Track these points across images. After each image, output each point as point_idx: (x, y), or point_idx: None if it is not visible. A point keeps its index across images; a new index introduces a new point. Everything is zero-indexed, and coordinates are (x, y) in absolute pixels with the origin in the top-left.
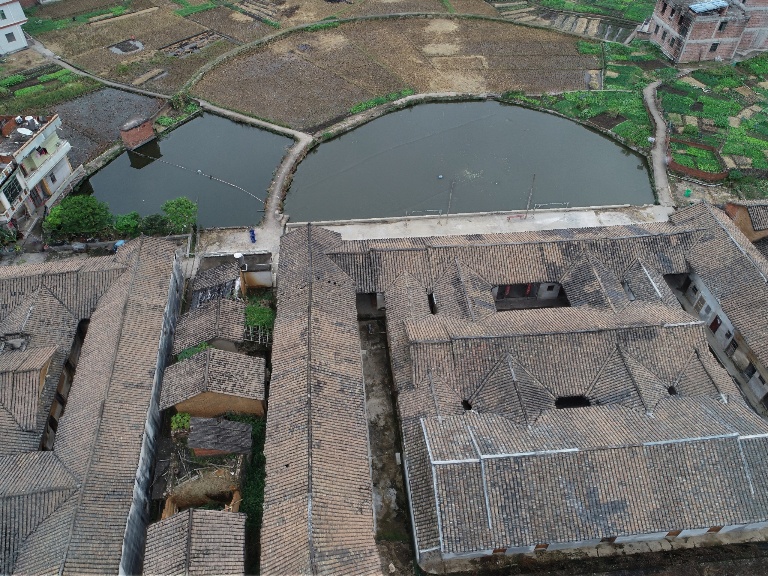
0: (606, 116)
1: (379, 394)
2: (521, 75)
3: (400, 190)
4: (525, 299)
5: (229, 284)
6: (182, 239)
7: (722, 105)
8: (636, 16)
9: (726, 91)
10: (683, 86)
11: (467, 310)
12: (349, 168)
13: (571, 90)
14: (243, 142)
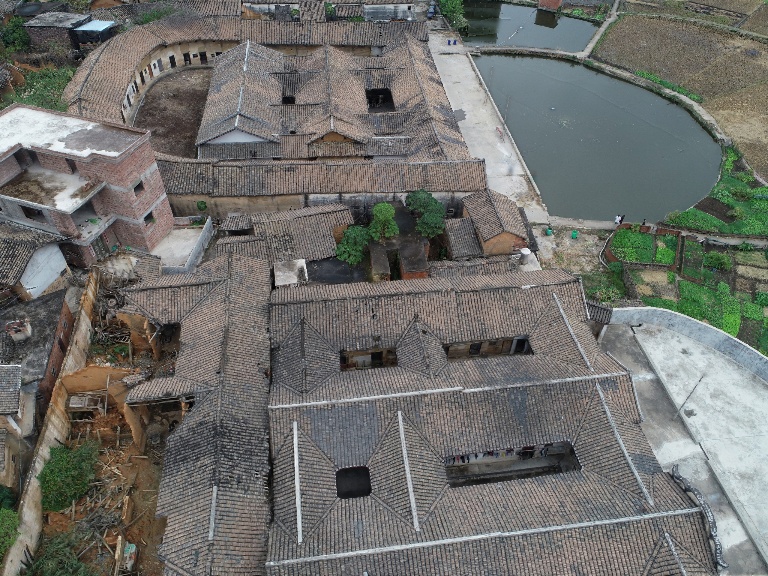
0: None
1: None
2: None
3: (526, 92)
4: None
5: None
6: None
7: None
8: None
9: None
10: None
11: None
12: (556, 79)
13: None
14: (567, 38)
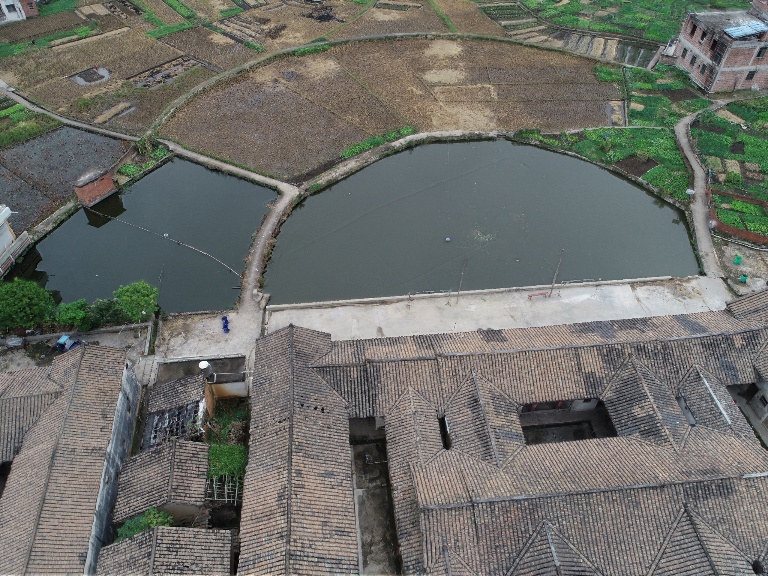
0: (634, 159)
1: (379, 557)
2: (534, 108)
3: (401, 258)
4: (556, 411)
5: (191, 407)
6: (140, 330)
7: (766, 146)
8: (658, 36)
9: (767, 127)
10: (719, 122)
11: (489, 448)
12: (341, 227)
13: (592, 126)
14: None
